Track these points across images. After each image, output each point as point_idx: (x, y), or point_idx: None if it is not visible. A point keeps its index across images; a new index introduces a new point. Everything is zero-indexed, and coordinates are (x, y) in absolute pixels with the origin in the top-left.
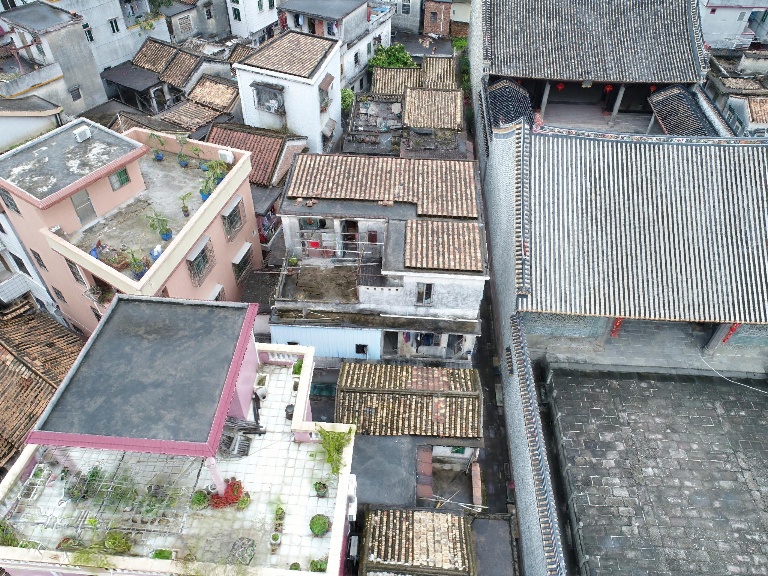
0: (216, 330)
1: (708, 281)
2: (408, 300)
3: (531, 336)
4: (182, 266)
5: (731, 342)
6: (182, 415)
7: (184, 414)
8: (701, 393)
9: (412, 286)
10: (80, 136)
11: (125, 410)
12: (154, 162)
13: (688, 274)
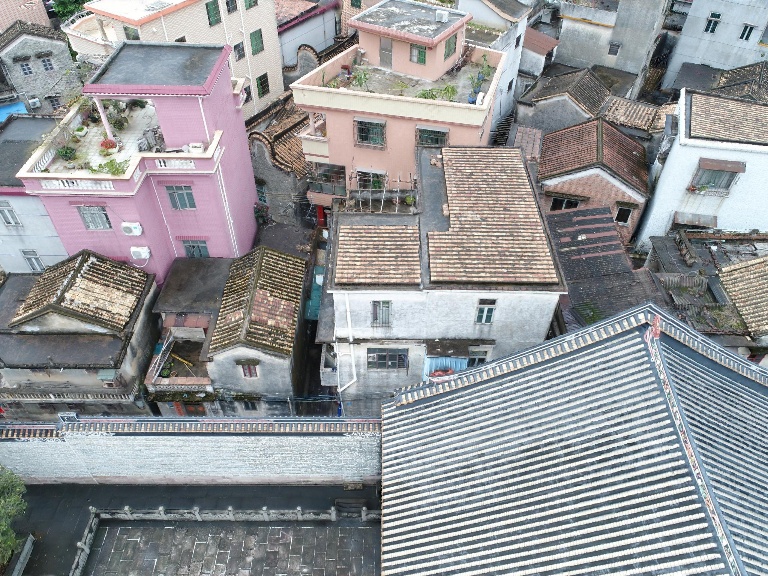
0: (187, 81)
1: None
2: None
3: None
4: (349, 118)
5: None
6: (118, 79)
7: (118, 79)
8: None
9: None
10: (438, 16)
11: (131, 63)
12: (475, 79)
13: None
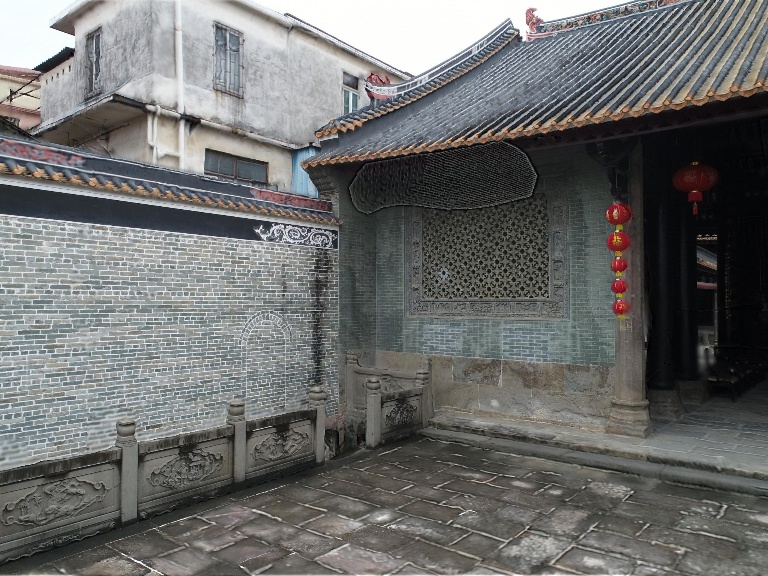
0: None
1: None
2: (80, 89)
3: None
4: None
5: None
6: None
7: None
8: None
9: (83, 49)
10: None
11: None
12: None
13: None
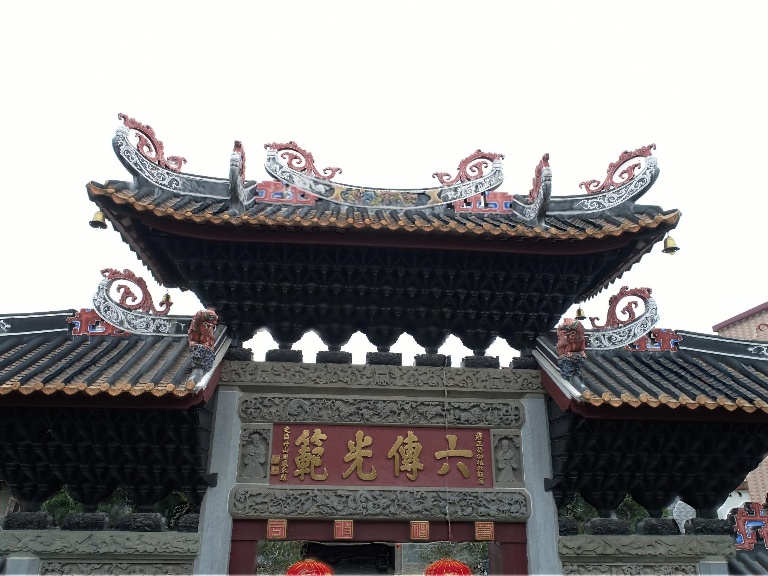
0: None
1: None
2: None
3: None
4: None
5: (413, 561)
6: None
7: None
8: None
9: None
10: None
11: None
12: None
13: None
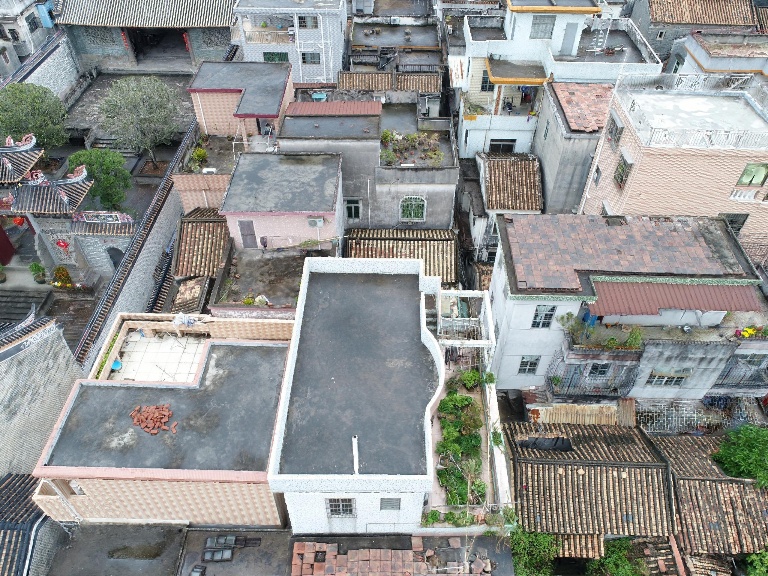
0: None
1: (159, 8)
2: None
3: (93, 56)
4: None
5: (201, 55)
6: None
7: None
8: (177, 80)
9: None
10: None
11: None
12: None
13: (150, 5)
